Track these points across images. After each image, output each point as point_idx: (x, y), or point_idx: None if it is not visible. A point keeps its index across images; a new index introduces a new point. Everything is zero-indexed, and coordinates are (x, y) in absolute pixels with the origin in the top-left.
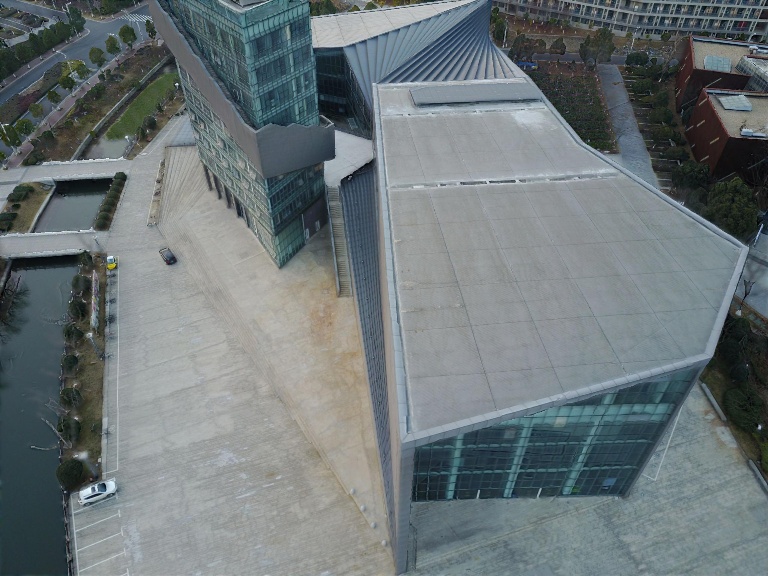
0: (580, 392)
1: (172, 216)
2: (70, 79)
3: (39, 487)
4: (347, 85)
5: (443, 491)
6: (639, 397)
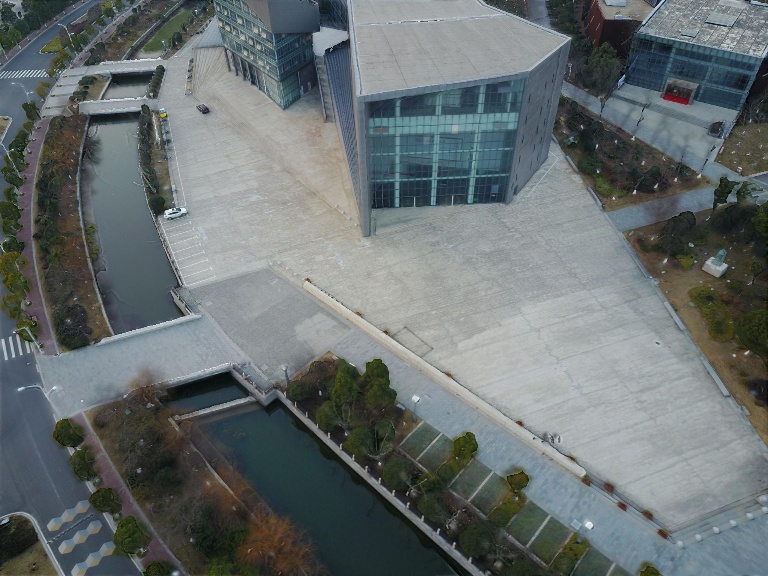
0: (454, 82)
1: (203, 87)
2: (112, 10)
3: (130, 233)
4: (328, 2)
5: (393, 200)
6: (497, 108)
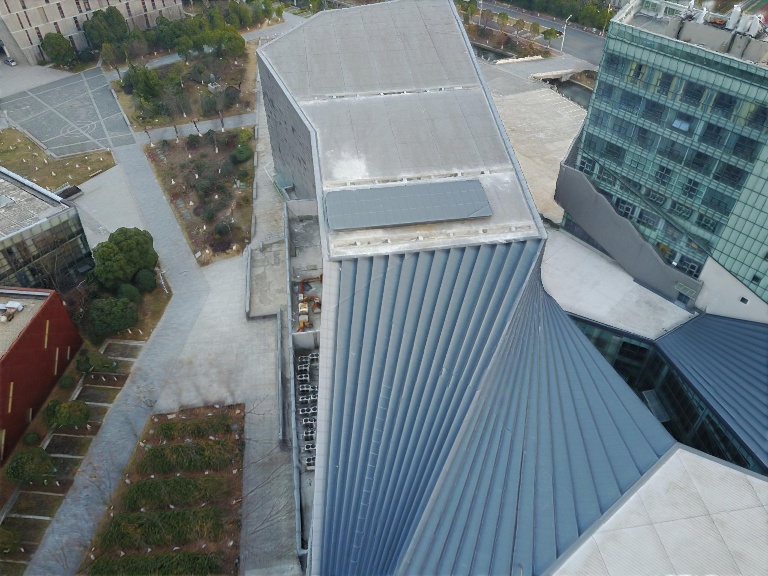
0: (381, 3)
1: None
2: None
3: None
4: None
5: None
6: None
